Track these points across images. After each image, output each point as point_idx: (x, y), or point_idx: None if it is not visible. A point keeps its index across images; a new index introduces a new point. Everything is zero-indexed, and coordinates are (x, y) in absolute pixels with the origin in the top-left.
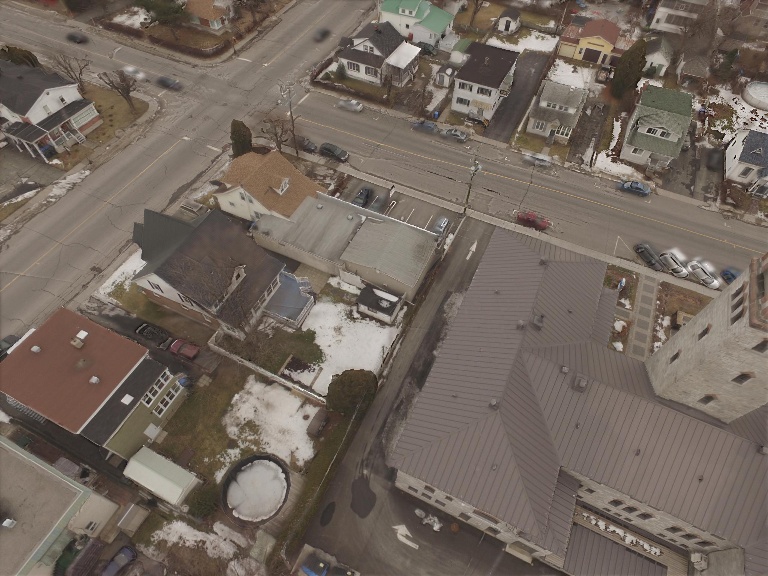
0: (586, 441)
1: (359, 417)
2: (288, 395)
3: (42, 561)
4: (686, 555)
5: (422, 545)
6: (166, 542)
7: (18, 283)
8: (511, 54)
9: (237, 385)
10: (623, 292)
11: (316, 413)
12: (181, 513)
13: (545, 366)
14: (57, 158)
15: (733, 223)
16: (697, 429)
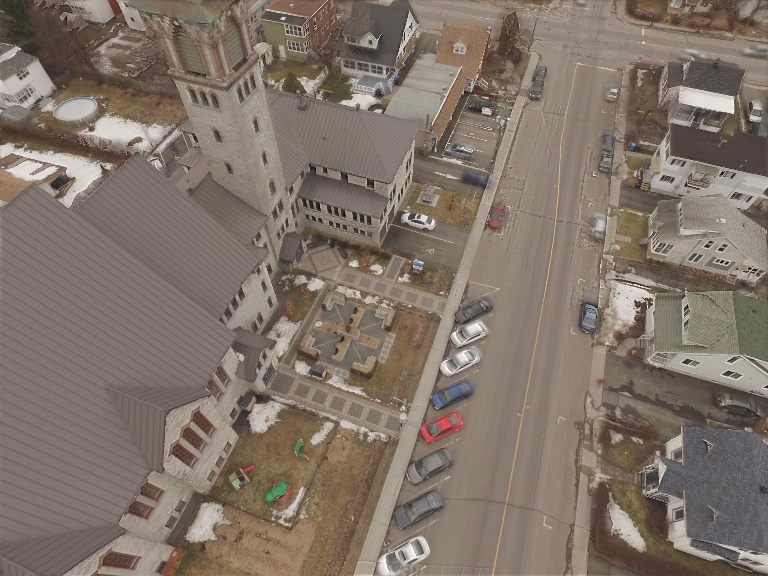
0: None
1: None
2: None
3: None
4: None
5: None
6: None
7: (373, 1)
8: (766, 170)
9: (312, 77)
10: (417, 276)
11: None
12: None
13: None
14: None
15: (569, 430)
16: None
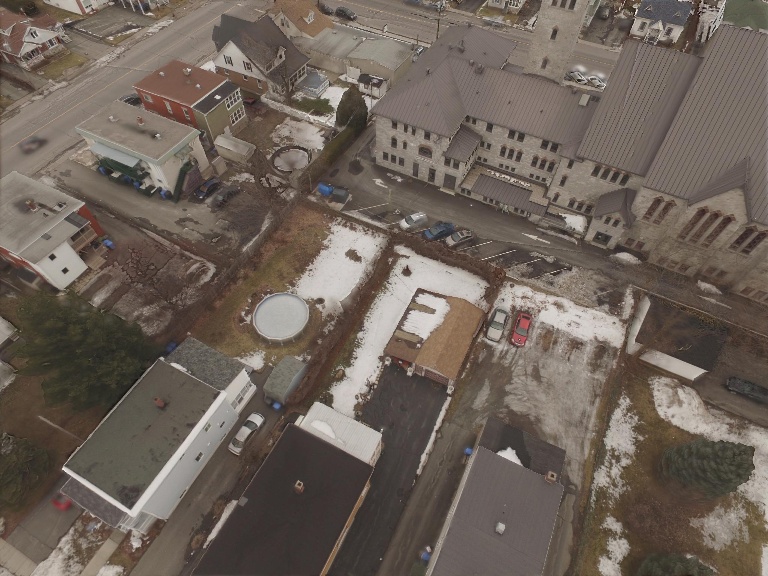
0: (482, 100)
1: (355, 128)
2: (311, 126)
3: (177, 155)
4: (545, 187)
5: (390, 186)
6: (238, 181)
7: (134, 73)
8: None
9: (279, 121)
10: None
11: (329, 128)
12: (247, 166)
13: (461, 63)
14: (150, 12)
15: None
16: (541, 86)
